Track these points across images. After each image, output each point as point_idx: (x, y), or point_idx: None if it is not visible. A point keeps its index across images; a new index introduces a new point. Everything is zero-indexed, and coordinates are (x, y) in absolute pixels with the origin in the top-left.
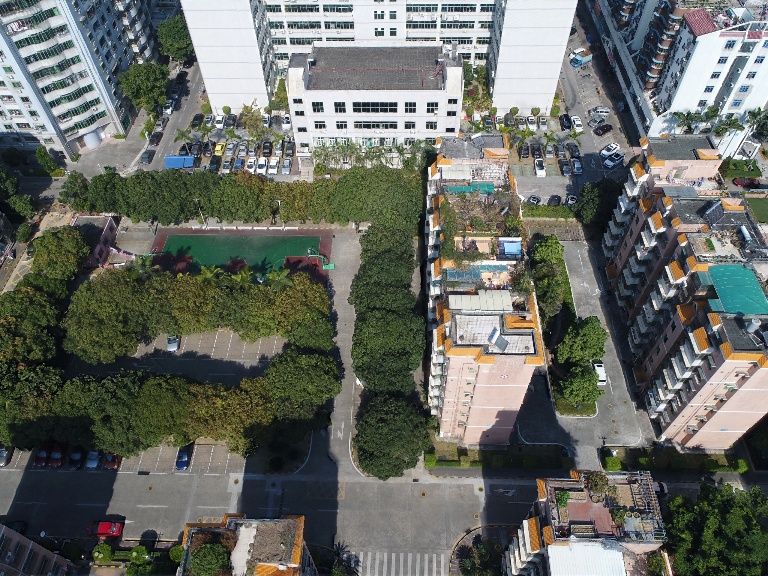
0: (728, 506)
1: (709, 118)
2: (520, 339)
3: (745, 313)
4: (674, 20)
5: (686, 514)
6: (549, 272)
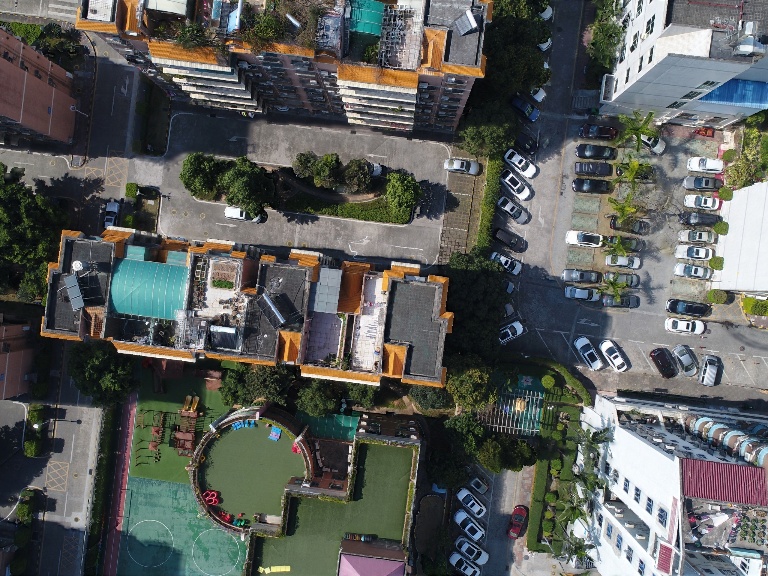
0: (30, 246)
1: (586, 477)
2: (107, 7)
3: (115, 276)
4: (759, 452)
5: (23, 201)
6: (349, 172)
